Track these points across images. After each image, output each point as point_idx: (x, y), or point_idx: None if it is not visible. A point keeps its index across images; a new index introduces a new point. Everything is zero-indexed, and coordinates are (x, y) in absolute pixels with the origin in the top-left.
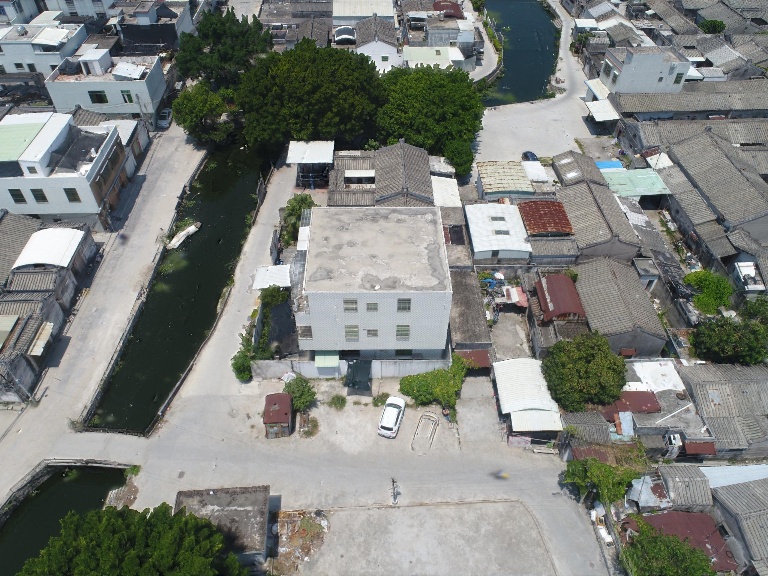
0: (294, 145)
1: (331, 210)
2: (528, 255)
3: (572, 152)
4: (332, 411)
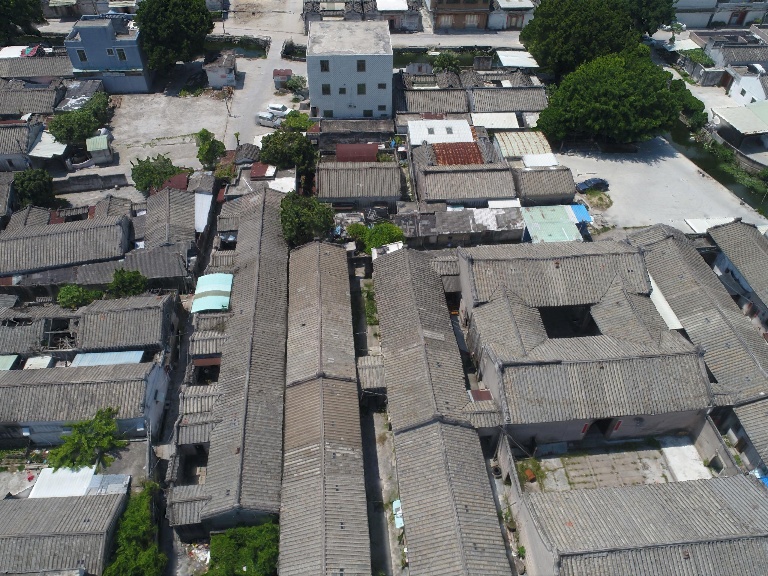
0: (524, 53)
1: (386, 26)
2: (411, 147)
3: (566, 168)
4: (290, 99)
